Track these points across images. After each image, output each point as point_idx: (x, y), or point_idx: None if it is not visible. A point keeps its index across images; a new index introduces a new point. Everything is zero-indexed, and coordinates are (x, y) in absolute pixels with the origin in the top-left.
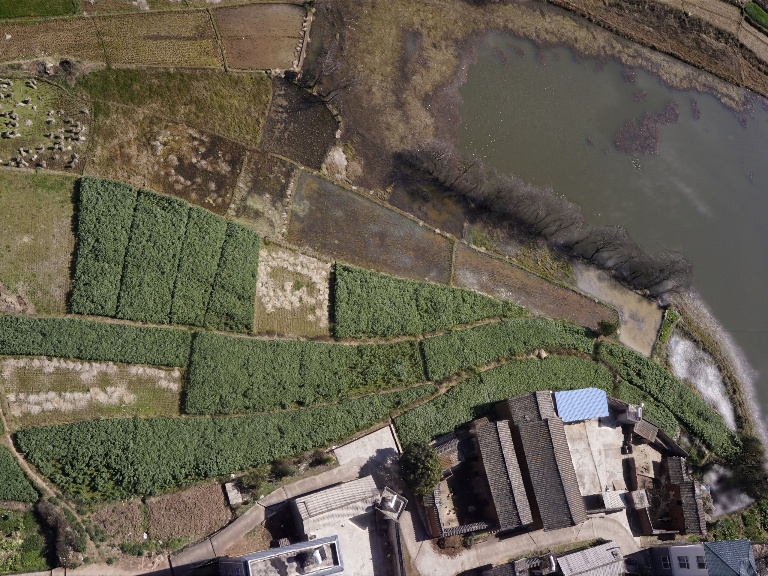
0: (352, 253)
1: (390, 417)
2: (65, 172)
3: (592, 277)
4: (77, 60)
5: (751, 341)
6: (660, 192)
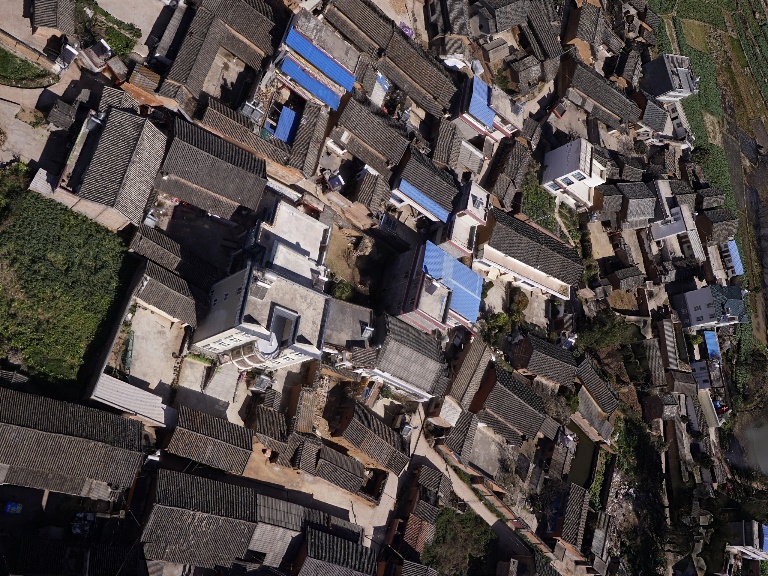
0: None
1: None
2: None
3: (761, 299)
4: None
5: None
6: None
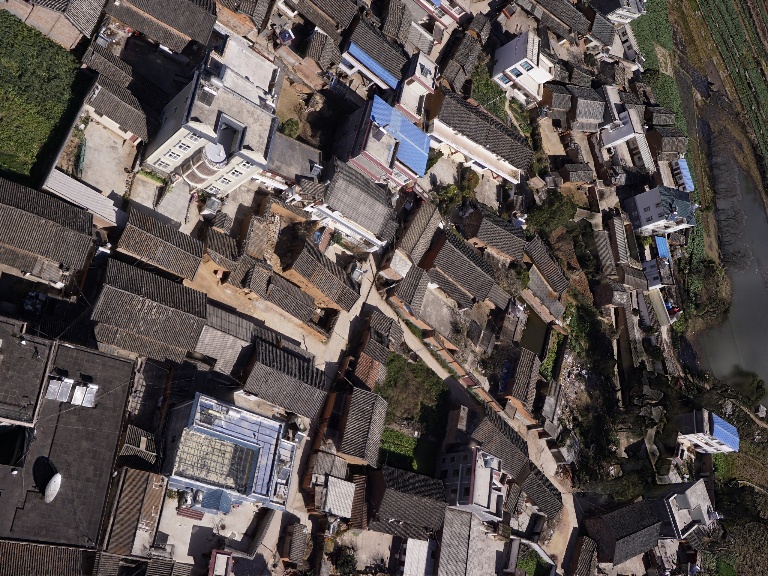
0: None
1: None
2: None
3: (714, 221)
4: None
5: (731, 335)
6: (755, 285)
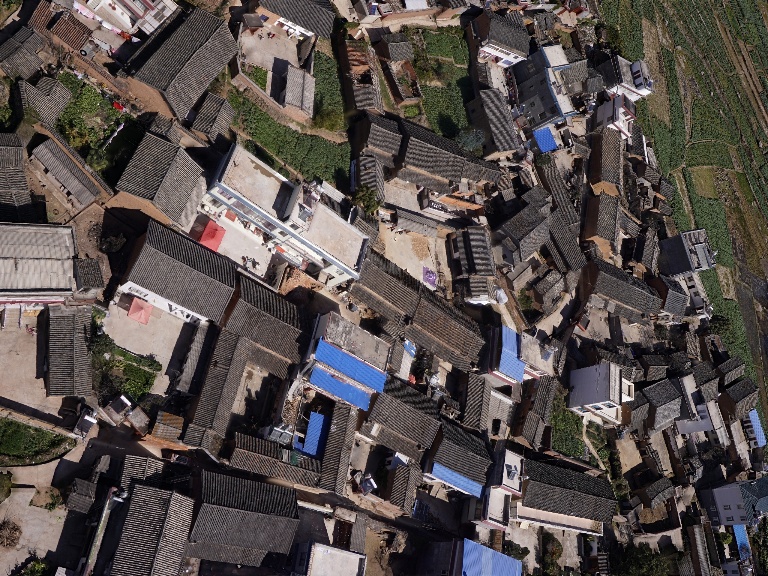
0: None
1: None
2: None
3: None
4: None
5: None
6: None
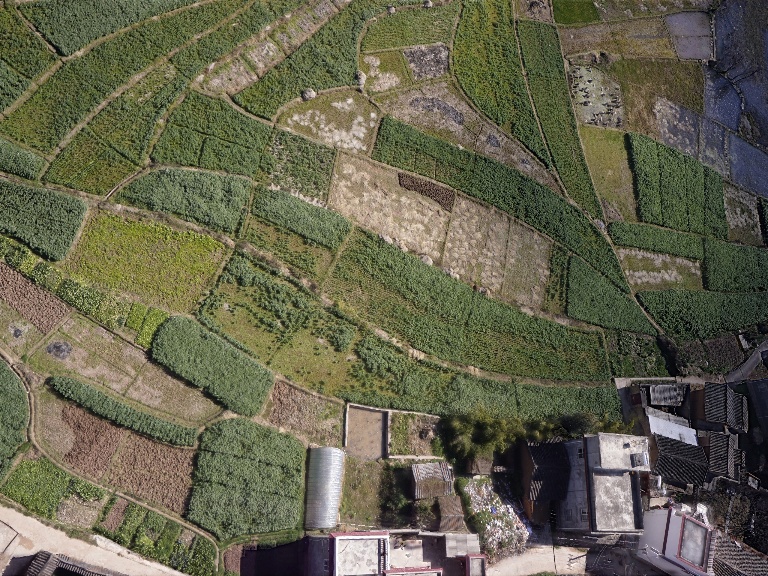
0: (765, 191)
1: None
2: (618, 129)
3: None
4: (608, 53)
5: None
6: None
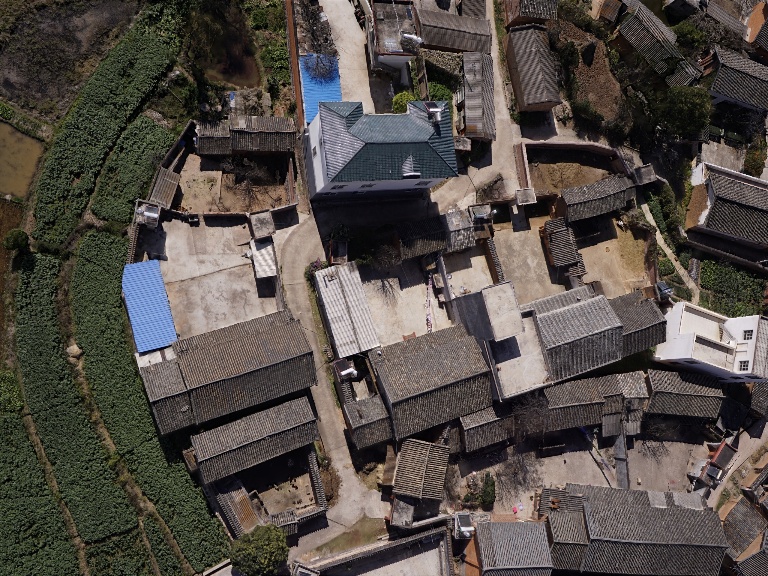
0: None
1: (193, 575)
2: None
3: None
4: None
5: None
6: None
